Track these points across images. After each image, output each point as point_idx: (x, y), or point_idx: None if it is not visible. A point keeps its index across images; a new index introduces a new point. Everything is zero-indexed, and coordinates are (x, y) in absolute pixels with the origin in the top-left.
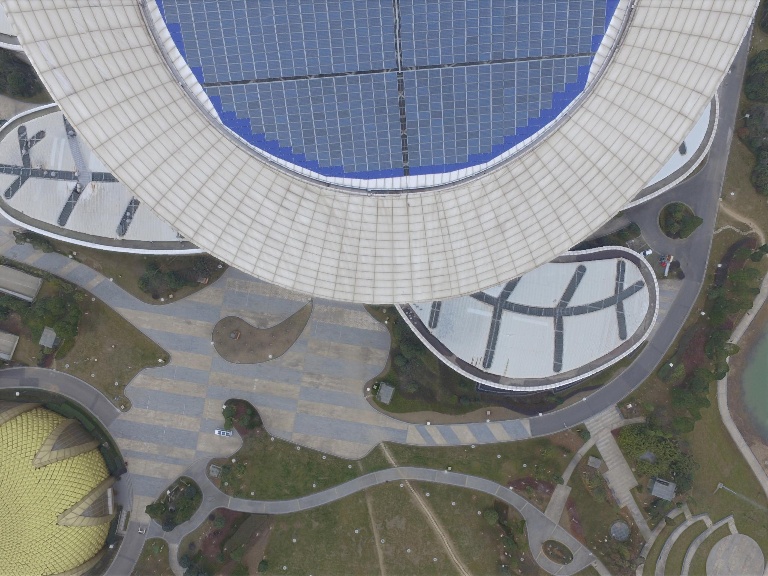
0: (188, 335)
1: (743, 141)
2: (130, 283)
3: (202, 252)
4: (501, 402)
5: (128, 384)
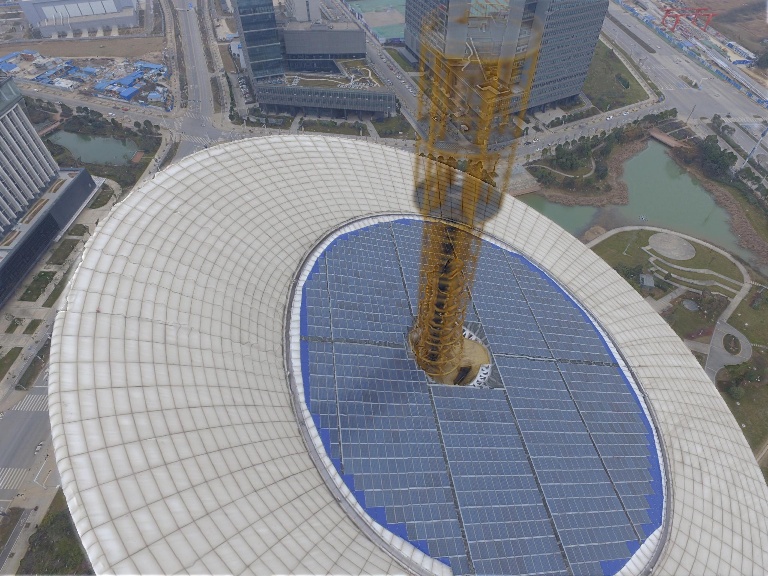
0: None
1: None
2: None
3: None
4: None
5: None
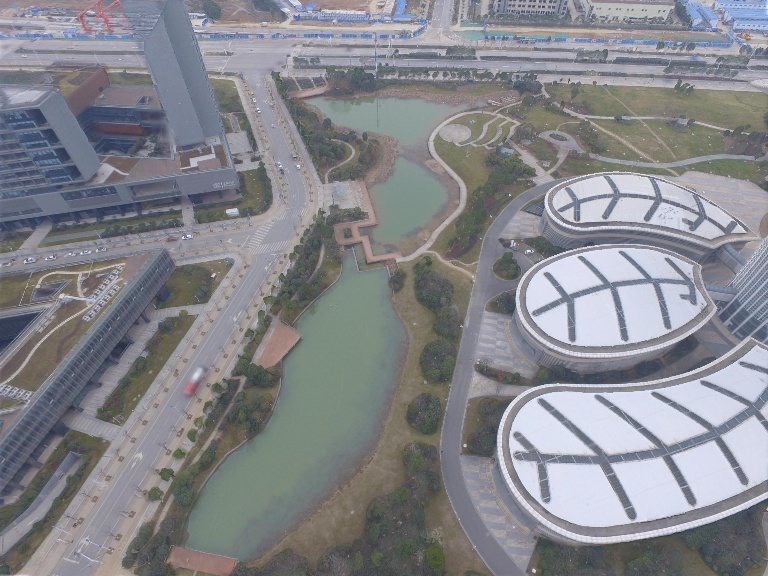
0: None
1: None
2: None
3: None
4: None
5: None
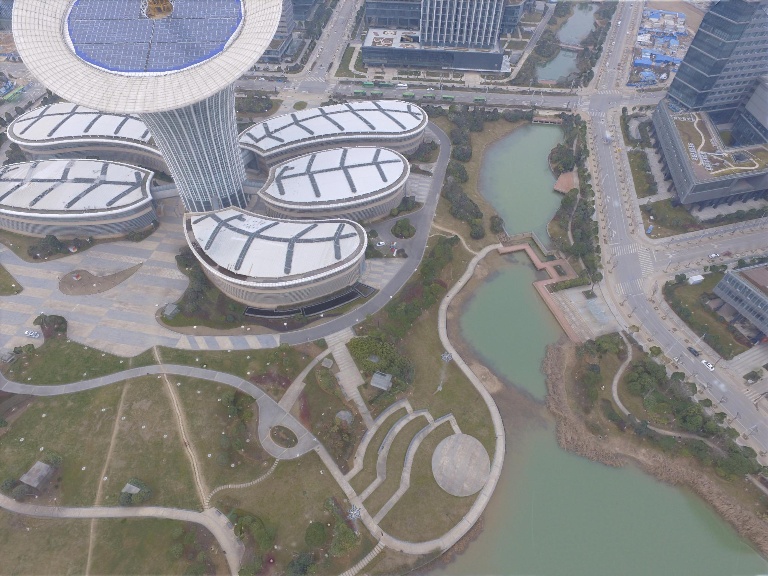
0: (44, 279)
1: (444, 197)
2: (23, 251)
3: (80, 233)
4: (259, 321)
5: None
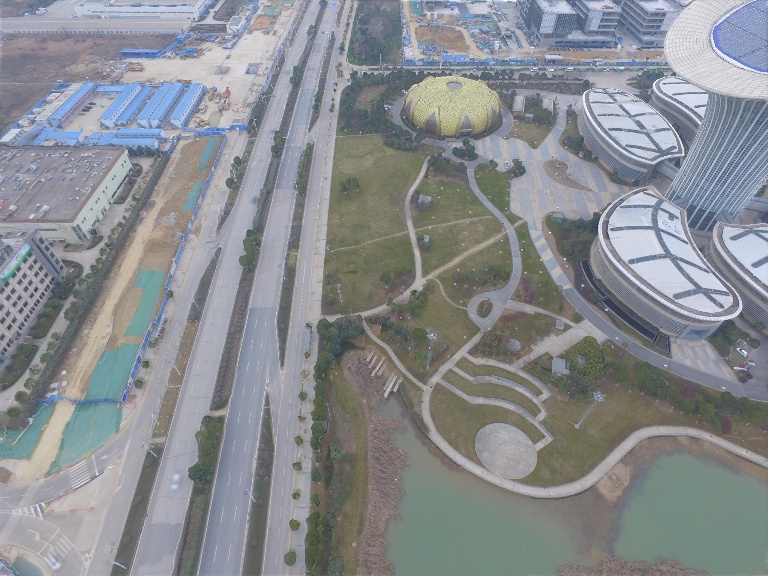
0: (550, 153)
1: None
2: (565, 136)
3: (597, 151)
4: (578, 271)
5: (516, 139)
